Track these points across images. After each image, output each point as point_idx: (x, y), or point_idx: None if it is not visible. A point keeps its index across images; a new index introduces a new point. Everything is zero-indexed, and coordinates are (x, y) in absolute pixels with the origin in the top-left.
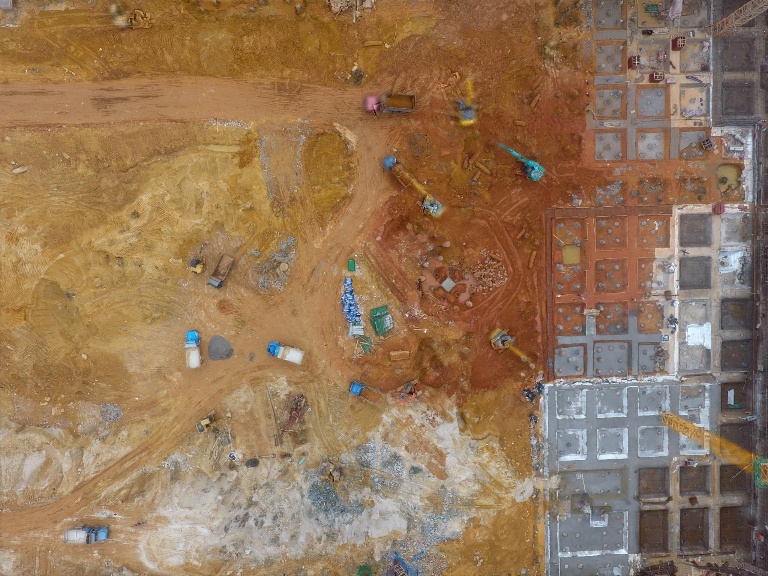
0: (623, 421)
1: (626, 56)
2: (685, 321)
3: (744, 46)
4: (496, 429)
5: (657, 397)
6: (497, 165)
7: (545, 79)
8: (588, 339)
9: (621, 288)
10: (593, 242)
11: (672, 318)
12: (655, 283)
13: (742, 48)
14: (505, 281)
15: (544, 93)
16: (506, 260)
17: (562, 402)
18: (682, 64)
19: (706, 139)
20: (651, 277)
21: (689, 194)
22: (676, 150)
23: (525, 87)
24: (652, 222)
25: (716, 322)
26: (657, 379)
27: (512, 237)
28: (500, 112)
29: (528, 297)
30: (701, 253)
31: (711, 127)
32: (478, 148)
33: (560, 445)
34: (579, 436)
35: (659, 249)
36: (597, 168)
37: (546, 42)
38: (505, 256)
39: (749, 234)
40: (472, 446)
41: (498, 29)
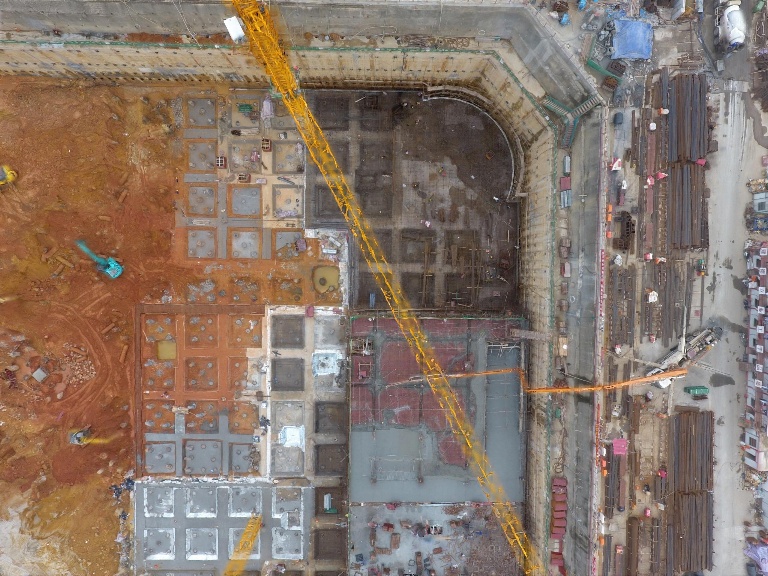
0: (212, 522)
1: (217, 155)
2: (280, 422)
3: (341, 149)
4: (70, 526)
5: (251, 498)
6: (80, 259)
7: (133, 175)
8: (177, 437)
9: (215, 386)
10: (182, 339)
11: (262, 419)
12: (250, 382)
13: (339, 151)
14: (93, 375)
15: (132, 189)
16: (93, 354)
17: (152, 499)
18: (277, 164)
19: (296, 241)
20: (246, 376)
21: (285, 294)
22: (268, 250)
23: (112, 182)
24: (247, 321)
25: (309, 425)
26: (249, 480)
27: (97, 331)
28: (74, 209)
29: (116, 392)
30: (294, 355)
31: (304, 229)
32: (52, 243)
33: (150, 543)
34: (170, 535)
35: (251, 349)
36: (187, 265)
37: (133, 139)
38: (92, 350)
39: (346, 337)
40: (28, 546)
41: (66, 127)
